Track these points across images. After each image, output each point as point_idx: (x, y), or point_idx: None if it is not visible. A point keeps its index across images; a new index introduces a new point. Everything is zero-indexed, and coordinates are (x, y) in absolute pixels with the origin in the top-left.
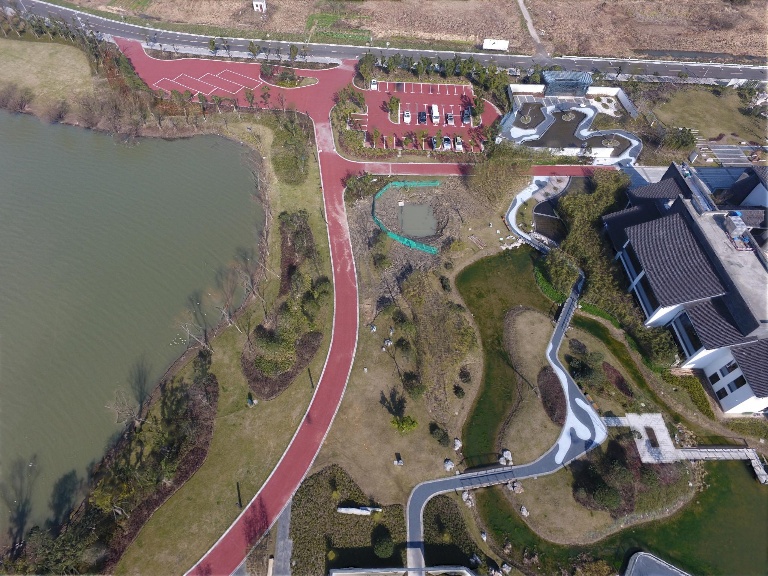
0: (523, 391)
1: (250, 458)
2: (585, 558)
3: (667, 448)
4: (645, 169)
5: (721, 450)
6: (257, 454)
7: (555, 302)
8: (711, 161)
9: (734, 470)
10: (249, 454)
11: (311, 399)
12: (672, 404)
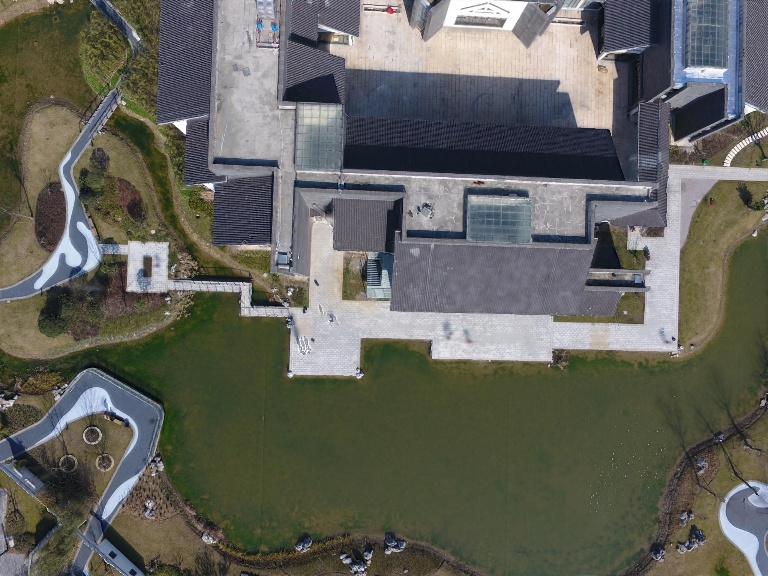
0: (22, 210)
1: None
2: (42, 370)
3: (159, 278)
4: None
5: (216, 282)
6: None
7: (98, 94)
8: None
9: (226, 301)
10: None
11: None
12: (189, 232)
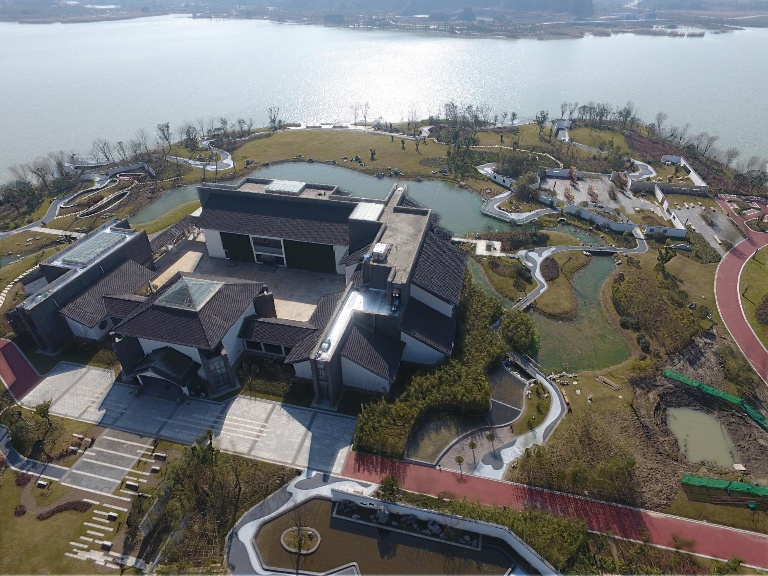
0: (570, 275)
1: (764, 271)
2: None
3: (482, 244)
4: (291, 459)
5: None
6: (761, 272)
7: None
8: (159, 454)
9: None
10: (767, 272)
11: (740, 290)
12: None
